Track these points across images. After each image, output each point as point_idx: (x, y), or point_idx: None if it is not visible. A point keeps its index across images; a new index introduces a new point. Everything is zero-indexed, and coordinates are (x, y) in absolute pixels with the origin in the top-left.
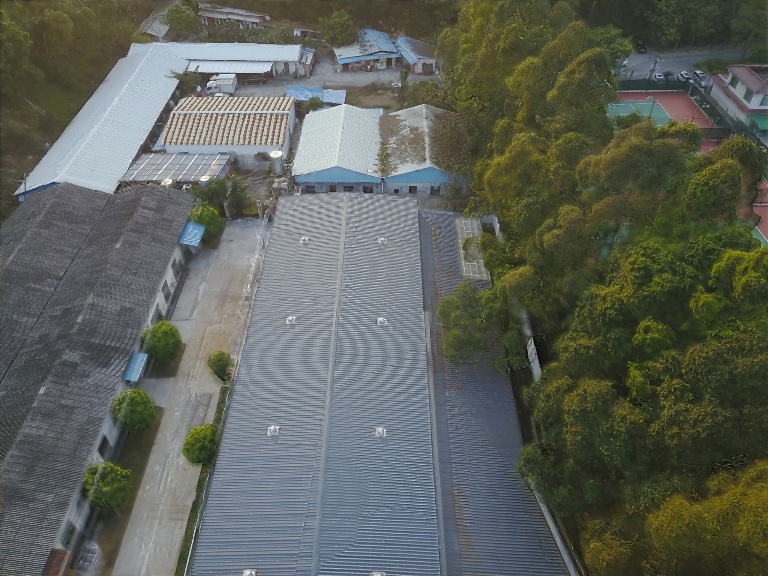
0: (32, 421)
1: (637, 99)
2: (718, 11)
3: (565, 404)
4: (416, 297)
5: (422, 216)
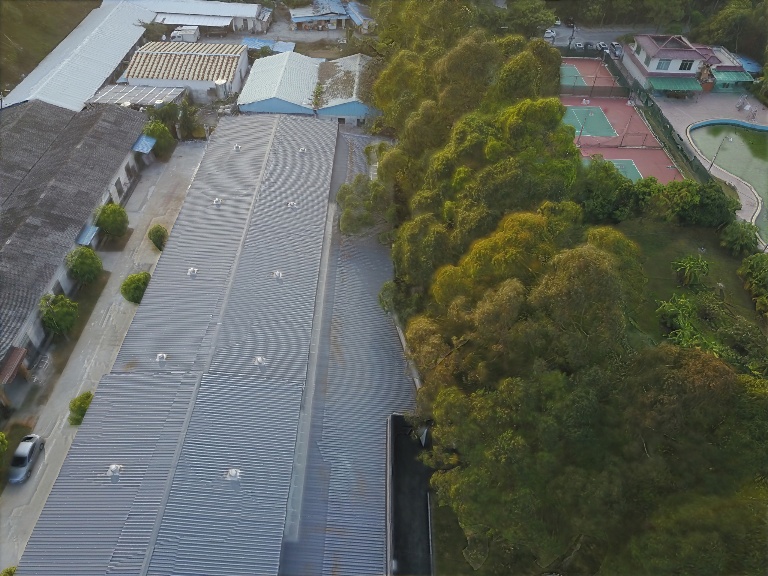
0: None
1: None
2: None
3: None
4: (324, 190)
5: (342, 137)
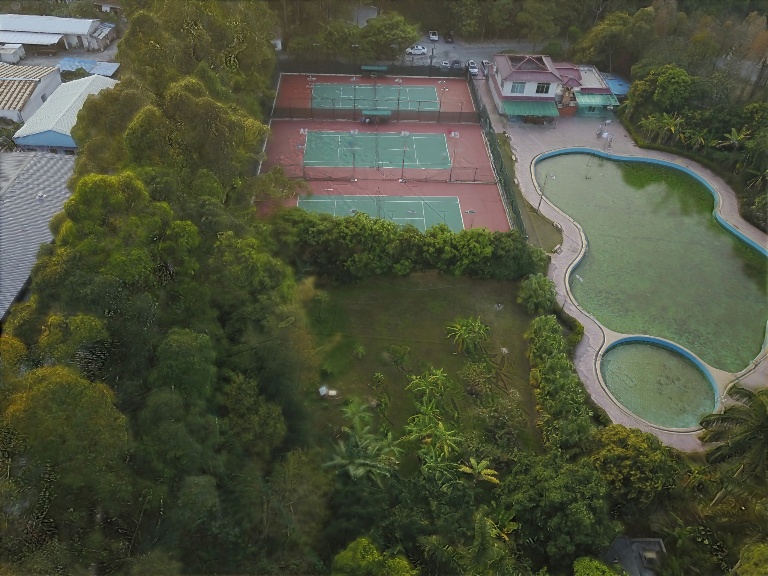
0: None
1: (415, 84)
2: (511, 4)
3: None
4: None
5: None
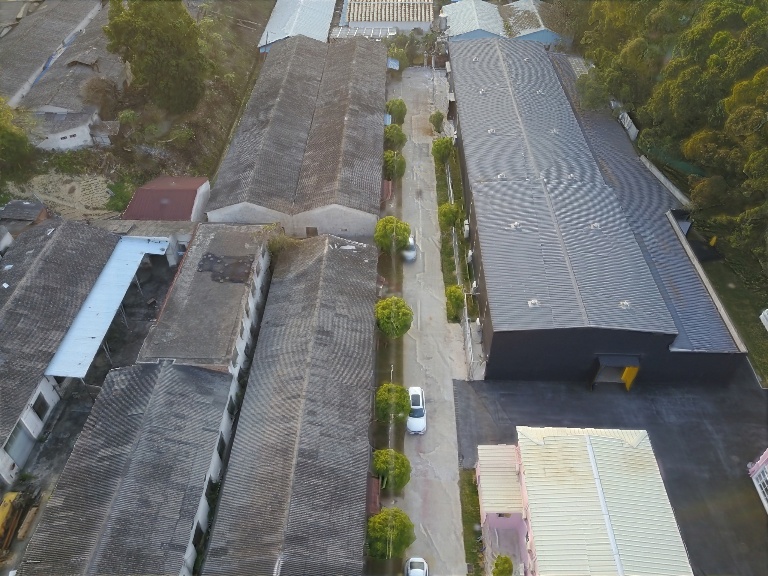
0: (348, 130)
1: None
2: None
3: (670, 89)
4: (557, 84)
5: None
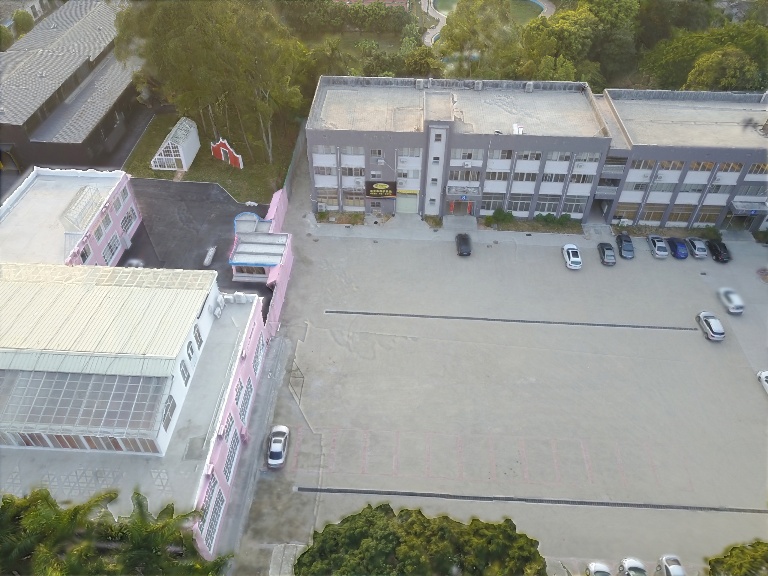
0: None
1: None
2: None
3: None
4: None
5: None
